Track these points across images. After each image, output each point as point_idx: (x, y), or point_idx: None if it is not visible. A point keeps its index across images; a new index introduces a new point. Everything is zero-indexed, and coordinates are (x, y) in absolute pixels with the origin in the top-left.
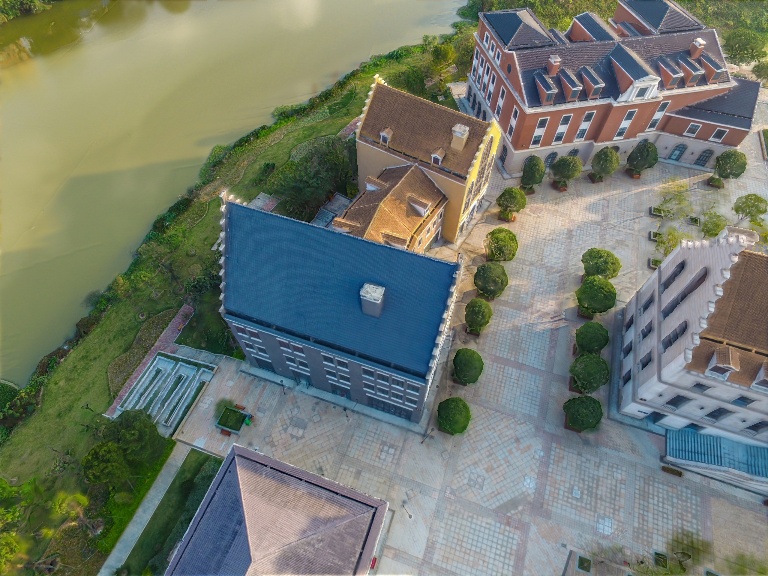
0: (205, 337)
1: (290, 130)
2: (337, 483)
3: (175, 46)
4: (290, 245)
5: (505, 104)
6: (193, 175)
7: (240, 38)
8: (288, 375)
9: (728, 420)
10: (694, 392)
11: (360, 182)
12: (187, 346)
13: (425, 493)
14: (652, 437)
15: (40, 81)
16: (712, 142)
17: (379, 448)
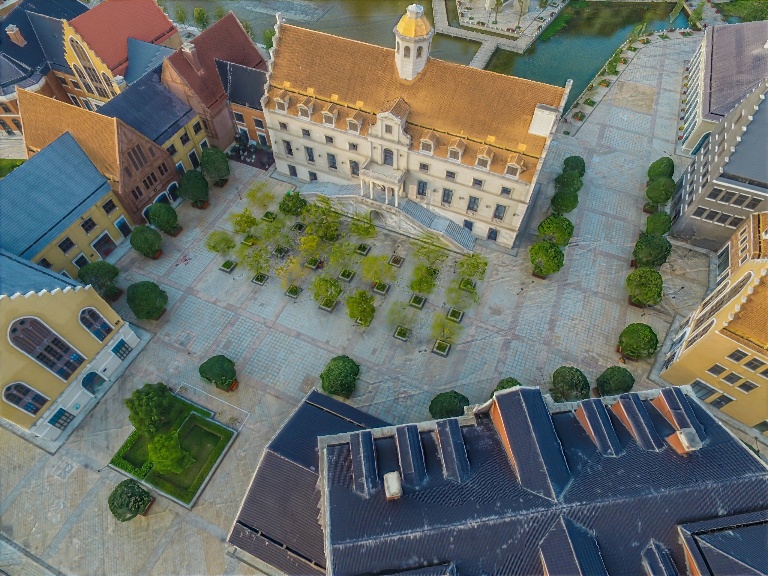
0: None
1: None
2: None
3: None
4: None
5: None
6: None
7: None
8: None
9: None
10: None
11: None
12: None
13: None
14: None
15: None
16: None
17: None
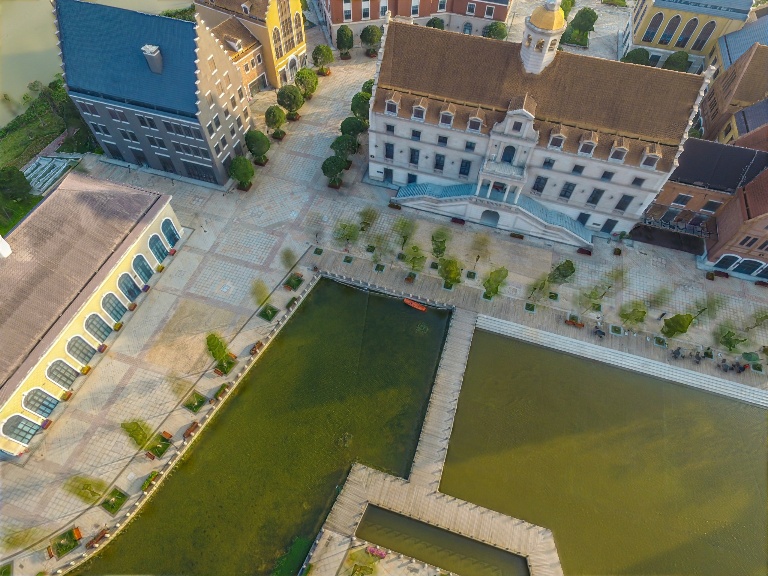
0: (75, 142)
1: None
2: None
3: None
4: (100, 25)
5: None
6: None
7: None
8: (132, 159)
9: (421, 161)
10: (389, 134)
11: None
12: (63, 152)
13: (219, 220)
14: (388, 191)
15: None
16: (487, 19)
17: (192, 199)
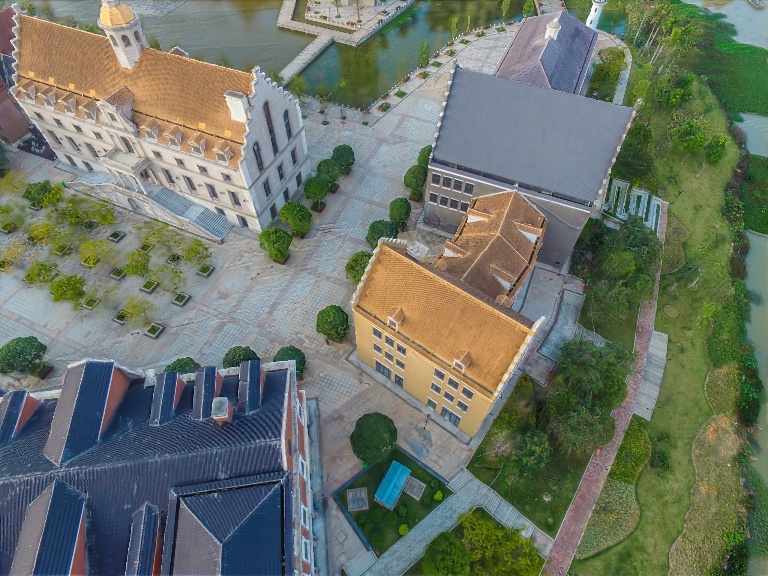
0: None
1: None
2: None
3: None
4: None
5: None
6: None
7: None
8: None
9: None
10: None
11: None
12: None
13: None
14: None
15: None
16: None
17: None
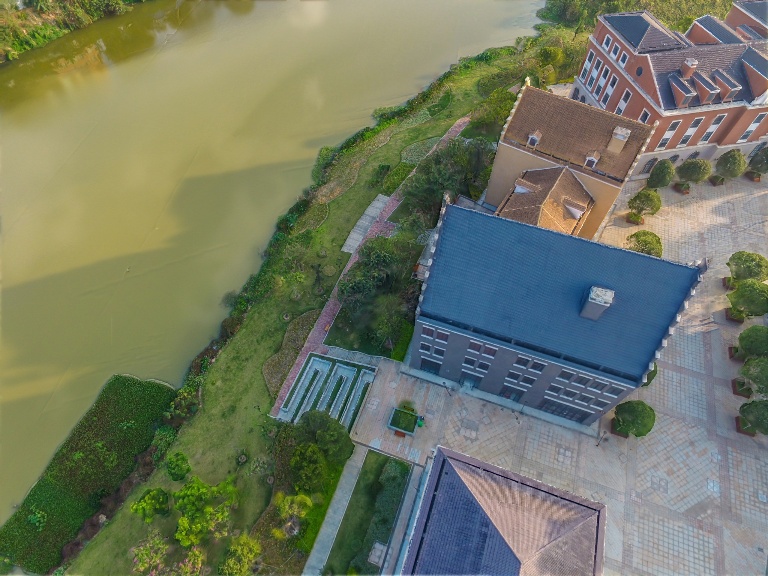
0: (359, 338)
1: (395, 132)
2: (550, 486)
3: (263, 48)
4: (509, 248)
5: (629, 107)
6: (306, 176)
7: (326, 40)
8: (453, 377)
9: None
10: None
11: (490, 184)
12: (338, 347)
13: (611, 496)
14: None
15: (136, 82)
16: None
17: (555, 451)
